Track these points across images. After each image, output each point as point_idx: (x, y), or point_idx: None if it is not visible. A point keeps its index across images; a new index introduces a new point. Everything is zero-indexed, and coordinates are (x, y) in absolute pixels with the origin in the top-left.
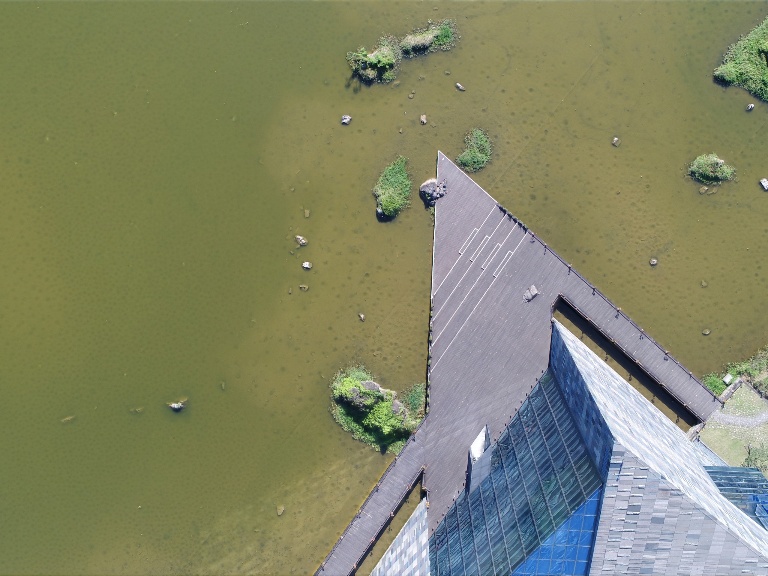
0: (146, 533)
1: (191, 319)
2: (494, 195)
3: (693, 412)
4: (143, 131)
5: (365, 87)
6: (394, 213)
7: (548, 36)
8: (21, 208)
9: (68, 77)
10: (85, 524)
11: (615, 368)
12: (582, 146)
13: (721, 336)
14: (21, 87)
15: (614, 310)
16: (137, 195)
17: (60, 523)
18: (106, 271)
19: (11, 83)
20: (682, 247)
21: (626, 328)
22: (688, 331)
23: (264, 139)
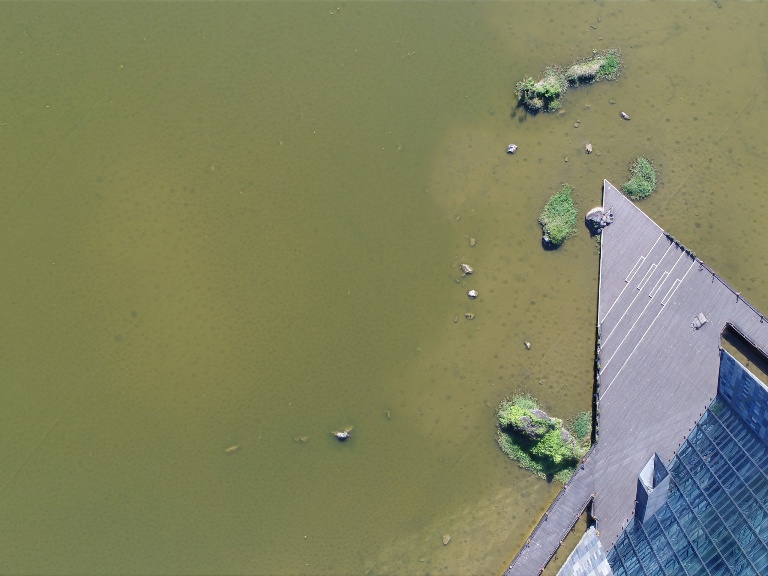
0: (311, 563)
1: (356, 348)
2: (659, 223)
3: None
4: (308, 160)
5: (530, 116)
6: (561, 241)
7: (712, 65)
8: (186, 237)
9: (234, 107)
10: (249, 554)
11: None
12: (746, 174)
13: None
14: (186, 117)
15: None
16: (302, 224)
17: (224, 554)
18: (271, 300)
19: (176, 113)
20: None
21: None
22: None
23: (429, 168)
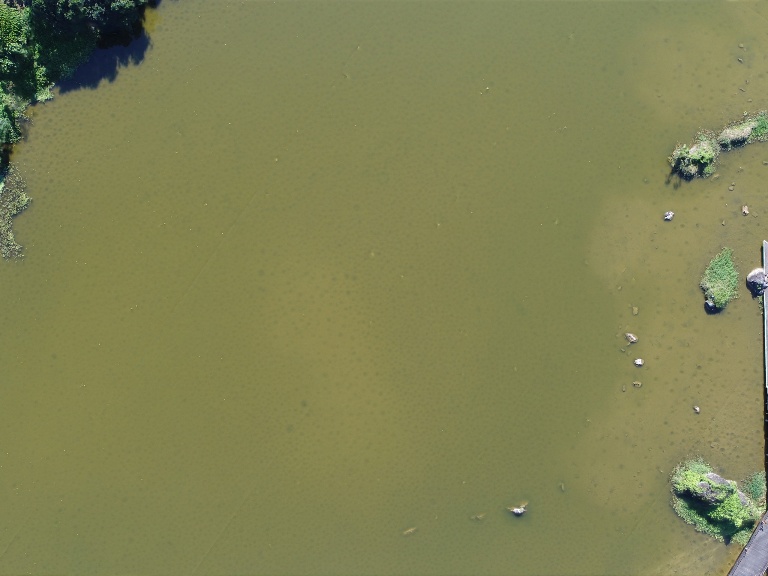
0: None
1: (526, 423)
2: None
3: None
4: (467, 240)
5: (685, 182)
6: (724, 305)
7: None
8: (351, 325)
9: (389, 192)
10: None
11: None
12: None
13: None
14: (343, 205)
15: None
16: (465, 304)
17: None
18: (439, 381)
19: (333, 202)
20: None
21: None
22: None
23: (587, 240)
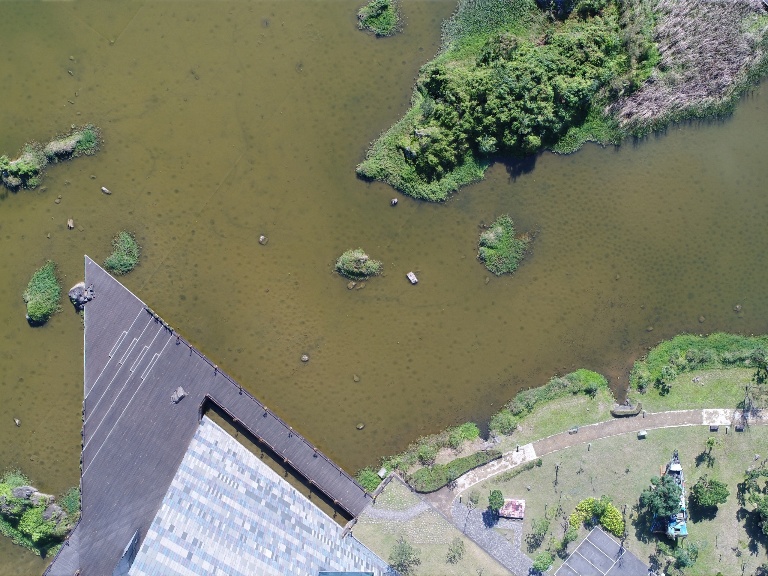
0: None
1: None
2: (144, 297)
3: (345, 508)
4: None
5: (12, 193)
6: (43, 318)
7: (191, 137)
8: None
9: None
10: None
11: (271, 465)
12: (229, 245)
13: (375, 430)
14: None
15: (262, 409)
16: None
17: None
18: None
19: None
20: (333, 343)
21: (275, 426)
22: (342, 426)
23: None
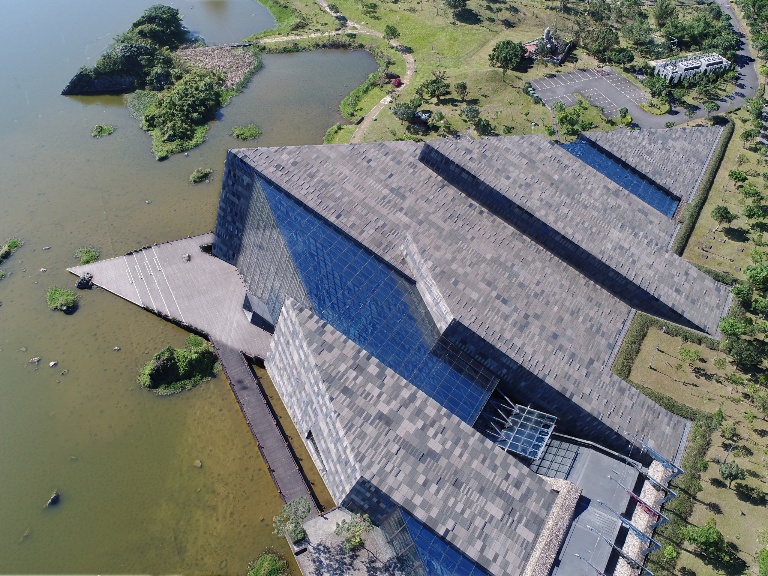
0: None
1: (7, 456)
2: None
3: None
4: None
5: None
6: (75, 304)
7: (67, 207)
8: None
9: None
10: None
11: None
12: (136, 215)
13: None
14: None
15: None
16: None
17: None
18: None
19: None
20: None
21: None
22: None
23: None
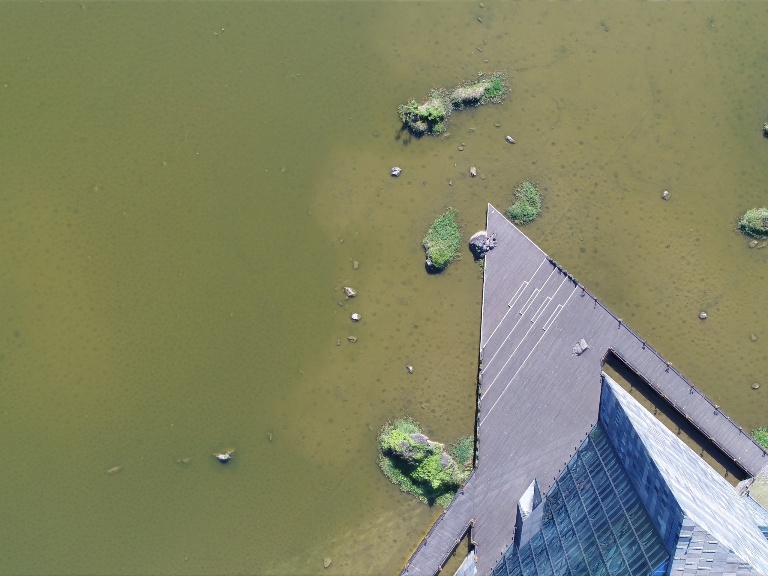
0: None
1: (239, 370)
2: (544, 248)
3: (743, 467)
4: (192, 181)
5: (415, 139)
6: (443, 265)
7: (598, 89)
8: (69, 258)
9: (117, 127)
10: (131, 575)
11: (664, 422)
12: (632, 199)
13: None
14: (70, 137)
15: (664, 364)
16: (186, 245)
17: (105, 574)
18: (154, 321)
19: (60, 133)
20: (732, 301)
21: (676, 382)
22: (737, 385)
23: (313, 190)
